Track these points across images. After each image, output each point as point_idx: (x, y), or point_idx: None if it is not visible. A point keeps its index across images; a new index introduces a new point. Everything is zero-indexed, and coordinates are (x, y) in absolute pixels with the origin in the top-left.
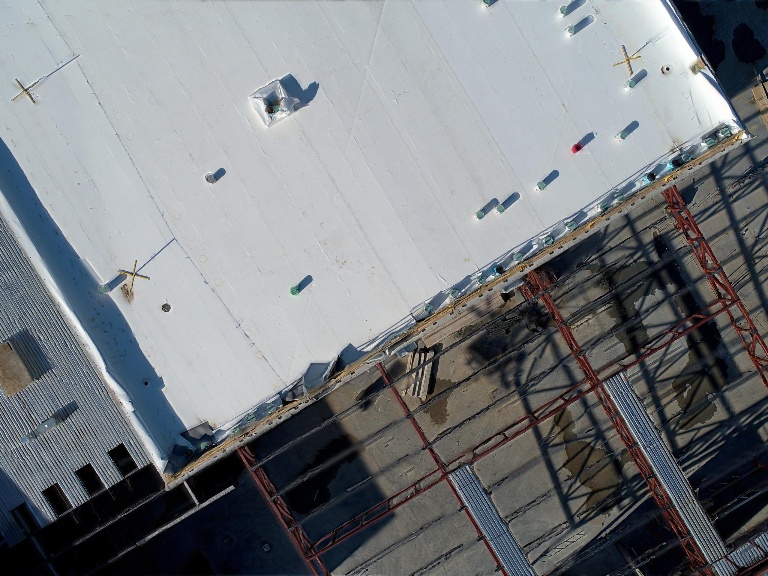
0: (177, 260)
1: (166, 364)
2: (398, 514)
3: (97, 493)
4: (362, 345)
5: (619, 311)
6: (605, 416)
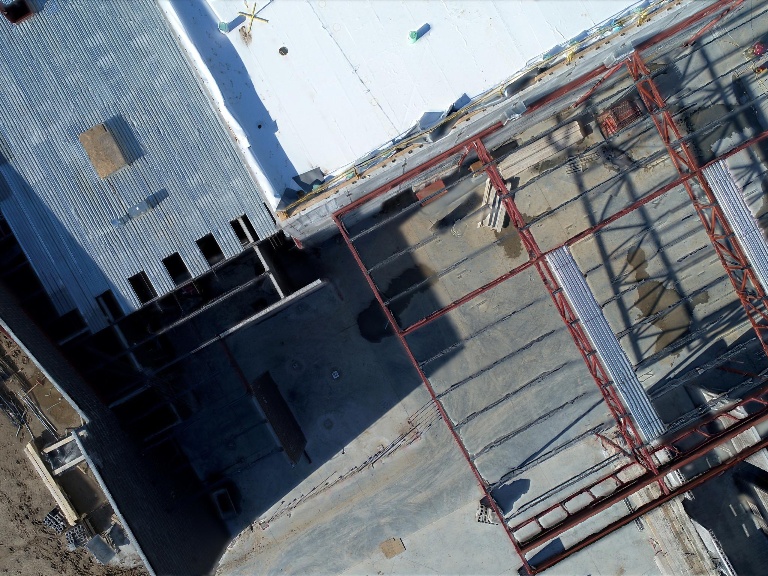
0: (296, 4)
1: (281, 108)
2: (468, 346)
3: (183, 282)
4: (476, 96)
5: (695, 153)
6: (678, 257)
